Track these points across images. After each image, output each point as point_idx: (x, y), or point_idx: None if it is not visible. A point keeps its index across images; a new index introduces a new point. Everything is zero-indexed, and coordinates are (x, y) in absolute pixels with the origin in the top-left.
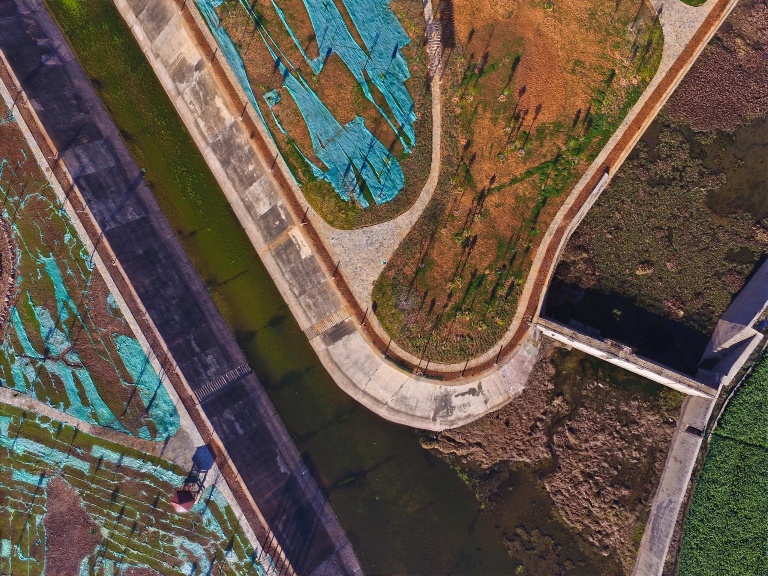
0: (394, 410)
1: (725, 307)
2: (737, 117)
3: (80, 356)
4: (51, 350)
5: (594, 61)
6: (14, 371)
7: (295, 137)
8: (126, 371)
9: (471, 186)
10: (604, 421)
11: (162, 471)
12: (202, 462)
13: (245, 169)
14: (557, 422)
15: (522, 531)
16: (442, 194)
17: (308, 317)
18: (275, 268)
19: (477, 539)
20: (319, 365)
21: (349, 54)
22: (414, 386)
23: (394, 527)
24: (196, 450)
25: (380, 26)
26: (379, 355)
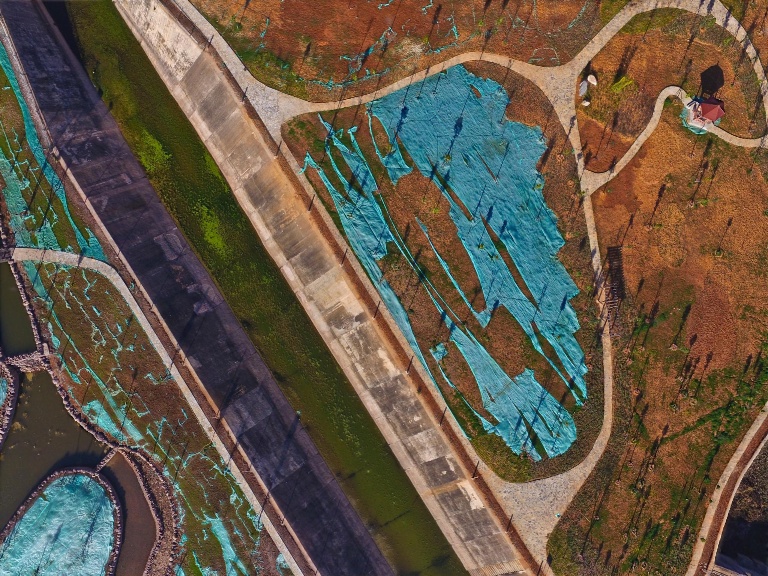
0: None
1: None
2: None
3: None
4: None
5: (764, 305)
6: None
7: (463, 391)
8: None
9: (644, 436)
10: None
11: None
12: None
13: (409, 418)
14: None
15: None
16: (616, 446)
17: (475, 560)
18: (438, 511)
19: None
20: None
21: (517, 306)
22: None
23: None
24: None
25: (548, 277)
26: None
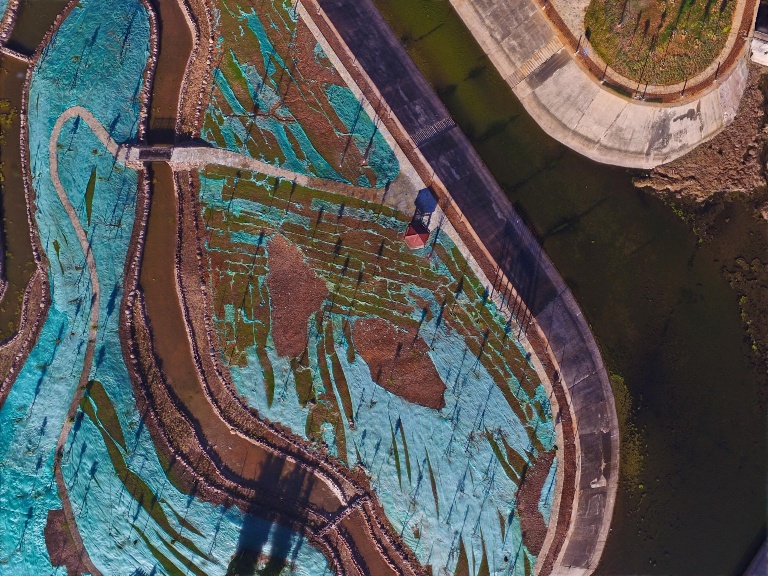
0: (606, 148)
1: None
2: None
3: (291, 110)
4: (260, 107)
5: None
6: (224, 132)
7: None
8: (339, 121)
9: None
10: None
11: (385, 218)
12: (425, 205)
13: None
14: None
15: (742, 261)
16: None
17: (512, 62)
18: (473, 16)
19: (696, 274)
20: (523, 113)
21: None
22: (632, 113)
23: (612, 269)
24: (418, 194)
25: None
26: (596, 82)
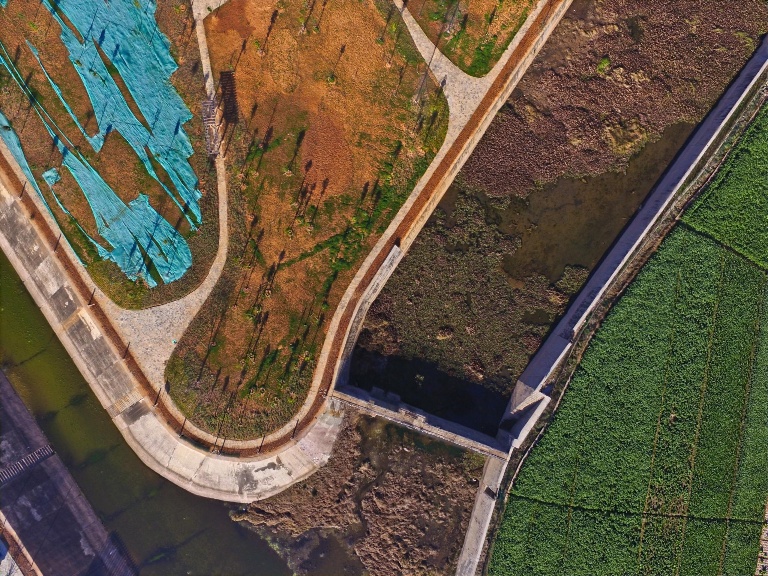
0: (200, 486)
1: (523, 368)
2: (529, 183)
3: None
4: None
5: (380, 134)
6: None
7: (78, 217)
8: None
9: (260, 262)
10: (410, 484)
11: None
12: None
13: (31, 249)
14: (365, 488)
15: None
16: (231, 271)
17: (108, 396)
18: (72, 347)
19: None
20: (124, 443)
21: (130, 131)
22: (212, 464)
23: None
24: None
25: (161, 101)
26: (174, 435)
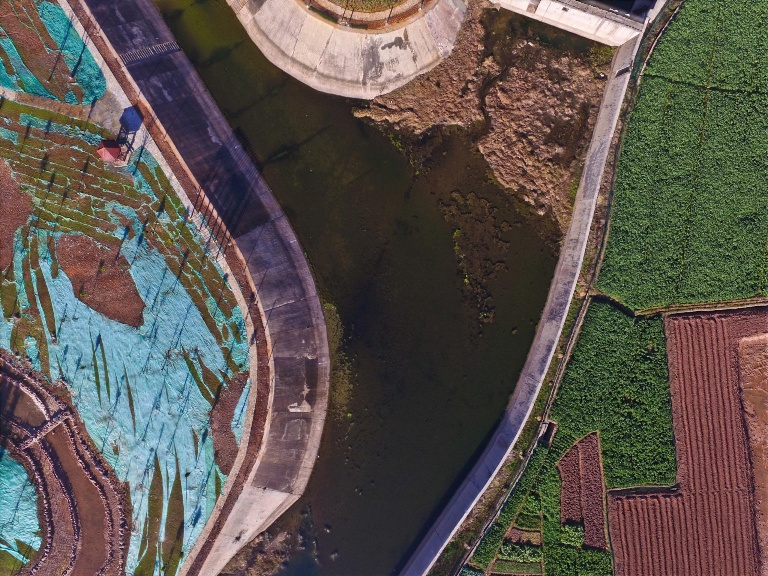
0: (323, 76)
1: None
2: None
3: (3, 25)
4: None
5: None
6: None
7: None
8: (50, 37)
9: None
10: (535, 80)
11: (90, 135)
12: (130, 124)
13: None
14: (488, 84)
15: (457, 195)
16: None
17: None
18: None
19: (413, 207)
20: (248, 40)
21: None
22: (340, 39)
23: (329, 199)
24: (123, 112)
25: None
26: (303, 6)
